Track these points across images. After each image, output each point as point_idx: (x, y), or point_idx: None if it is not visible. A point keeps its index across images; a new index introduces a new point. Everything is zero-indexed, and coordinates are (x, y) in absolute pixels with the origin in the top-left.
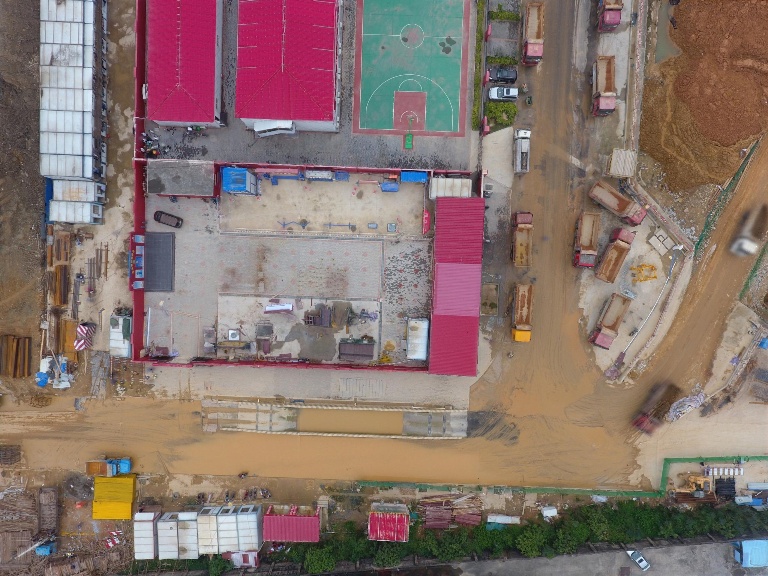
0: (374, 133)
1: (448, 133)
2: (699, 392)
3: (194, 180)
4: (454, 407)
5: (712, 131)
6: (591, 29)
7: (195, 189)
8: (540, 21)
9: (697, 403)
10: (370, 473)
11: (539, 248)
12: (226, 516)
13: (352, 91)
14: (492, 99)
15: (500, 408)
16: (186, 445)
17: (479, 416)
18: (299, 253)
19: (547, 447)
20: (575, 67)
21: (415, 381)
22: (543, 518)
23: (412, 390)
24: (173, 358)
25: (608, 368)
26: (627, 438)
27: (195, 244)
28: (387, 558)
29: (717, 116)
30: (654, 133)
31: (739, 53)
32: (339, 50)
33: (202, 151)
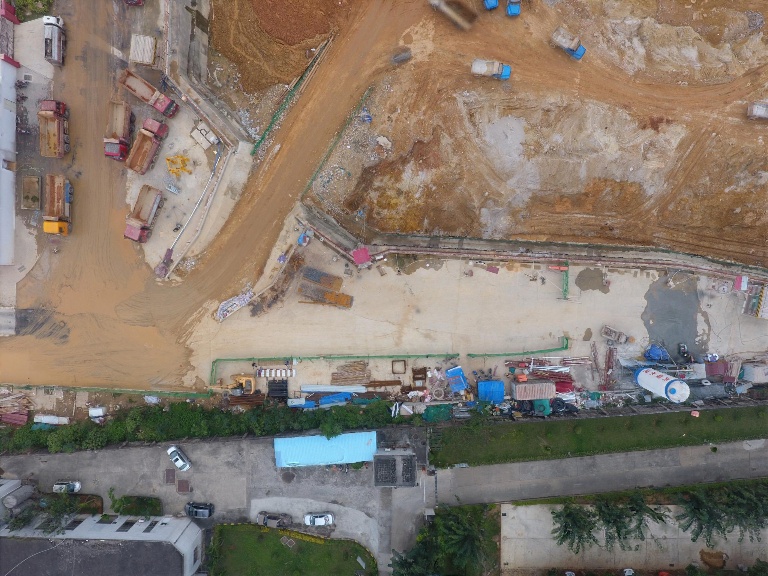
0: None
1: None
2: (248, 291)
3: None
4: (1, 304)
5: (276, 29)
6: None
7: None
8: None
9: (242, 301)
10: None
11: (83, 141)
12: None
13: None
14: None
15: (49, 306)
16: None
17: (28, 314)
18: None
19: (98, 346)
20: None
21: None
22: (90, 418)
23: None
24: None
25: (157, 265)
26: (178, 338)
27: None
28: None
29: (276, 13)
30: (224, 32)
31: None
32: None
33: None
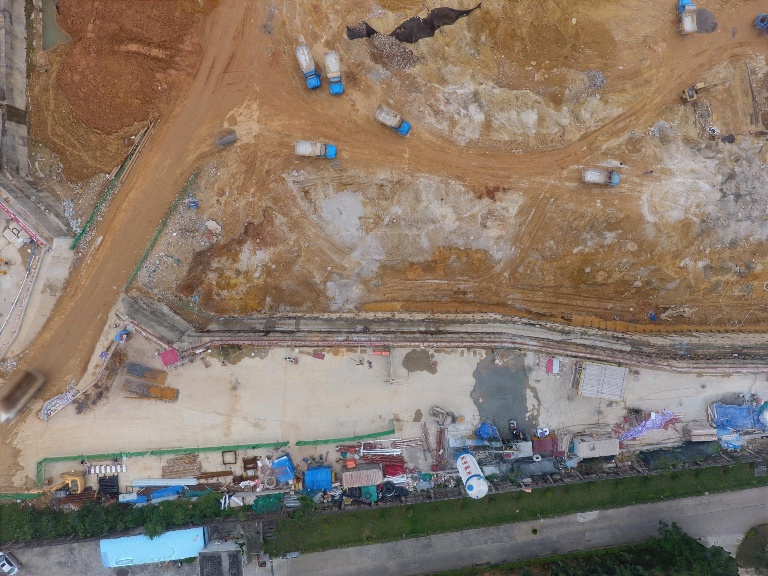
0: None
1: None
2: (72, 388)
3: None
4: None
5: (92, 119)
6: None
7: None
8: None
9: (65, 400)
10: None
11: None
12: None
13: None
14: None
15: None
16: None
17: None
18: None
19: None
20: None
21: None
22: None
23: None
24: None
25: None
26: (4, 438)
27: None
28: None
29: (89, 103)
30: (42, 123)
31: (122, 38)
32: None
33: None
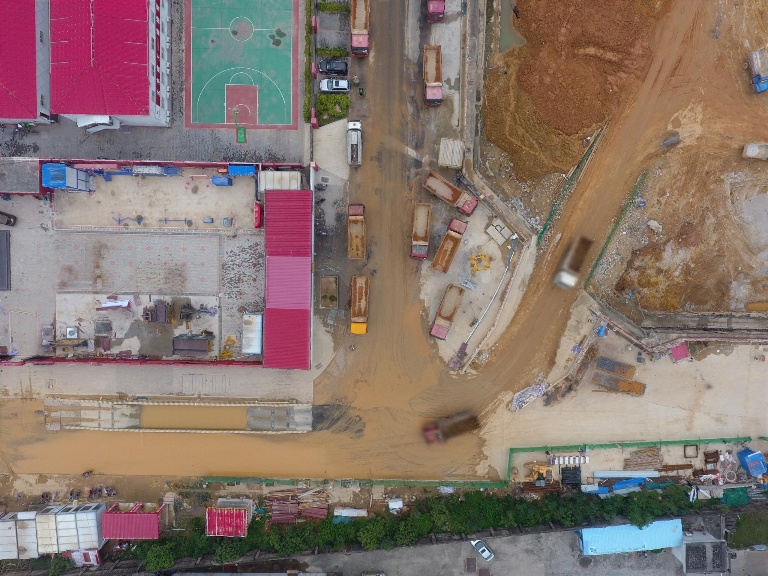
0: (206, 127)
1: (281, 126)
2: (542, 381)
3: (19, 177)
4: (298, 401)
5: (554, 120)
6: (422, 19)
7: (21, 186)
8: (367, 12)
9: (539, 392)
10: (219, 469)
11: (378, 240)
12: (65, 515)
13: (183, 85)
14: (323, 91)
15: (345, 401)
16: (30, 444)
17: (324, 409)
18: (136, 249)
19: (393, 439)
20: (408, 58)
21: (258, 376)
22: (389, 510)
23: (255, 385)
24: (12, 357)
25: (451, 359)
26: (472, 429)
27: (30, 242)
28: (224, 553)
29: (557, 105)
30: (499, 123)
31: (581, 41)
32: (166, 44)
33: (33, 148)
